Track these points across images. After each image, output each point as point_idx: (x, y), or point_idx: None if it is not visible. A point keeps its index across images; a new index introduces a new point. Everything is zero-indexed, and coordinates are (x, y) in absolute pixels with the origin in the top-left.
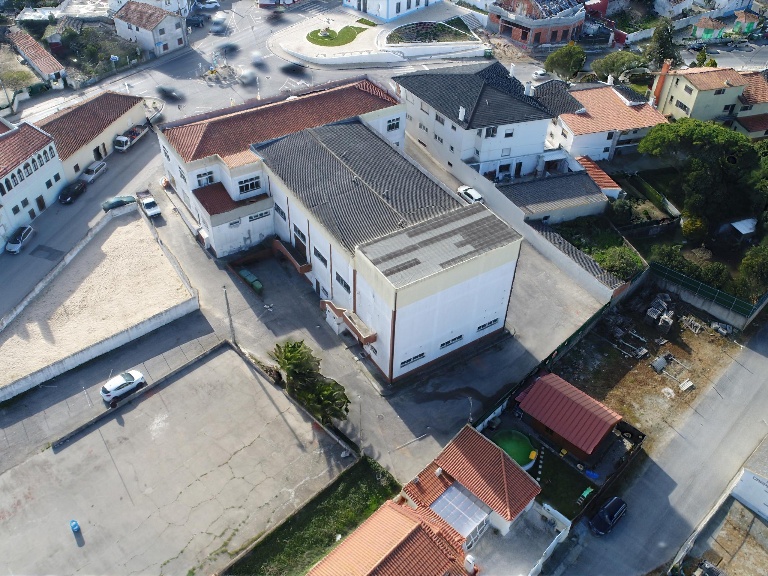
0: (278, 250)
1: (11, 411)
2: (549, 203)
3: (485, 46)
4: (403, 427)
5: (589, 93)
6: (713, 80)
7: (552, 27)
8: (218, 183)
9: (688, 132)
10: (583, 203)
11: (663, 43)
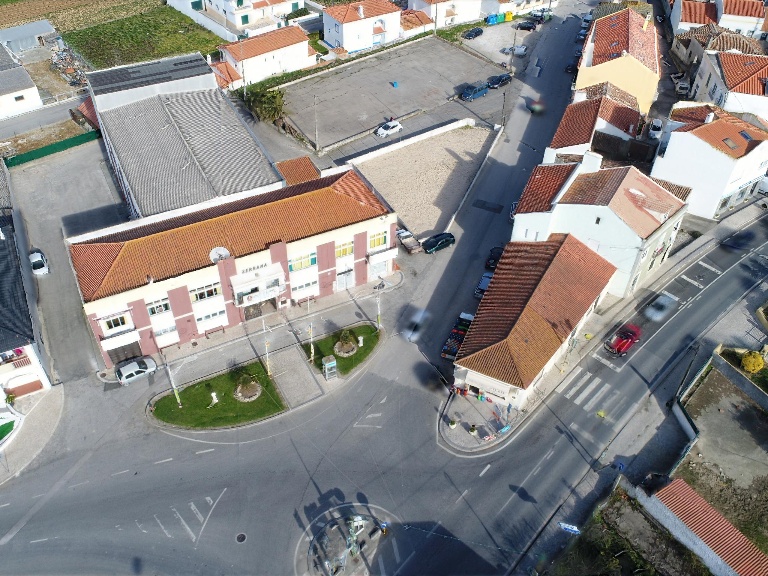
0: None
1: None
2: None
3: None
4: None
5: None
6: None
7: None
8: None
9: None
10: None
11: None
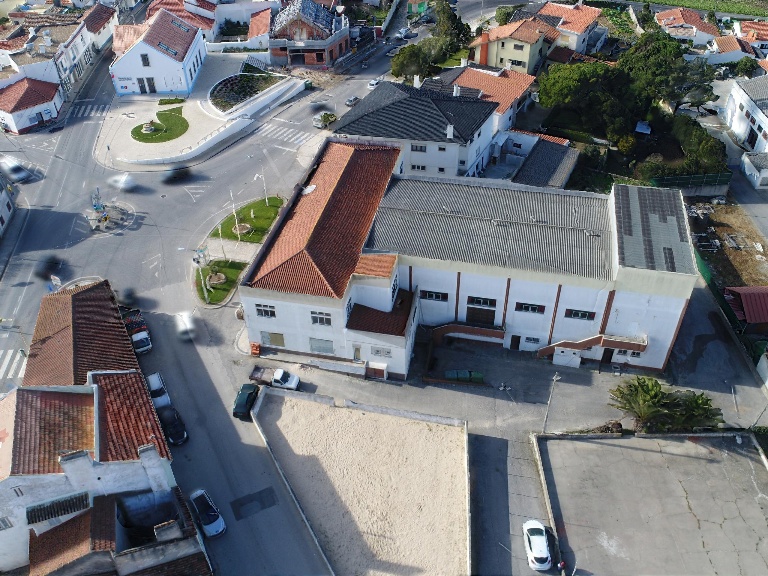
0: (442, 336)
1: None
2: (556, 174)
3: (299, 80)
4: (715, 394)
5: (463, 79)
6: (529, 33)
7: (338, 41)
8: (354, 306)
9: (581, 75)
10: (572, 162)
11: (453, 20)
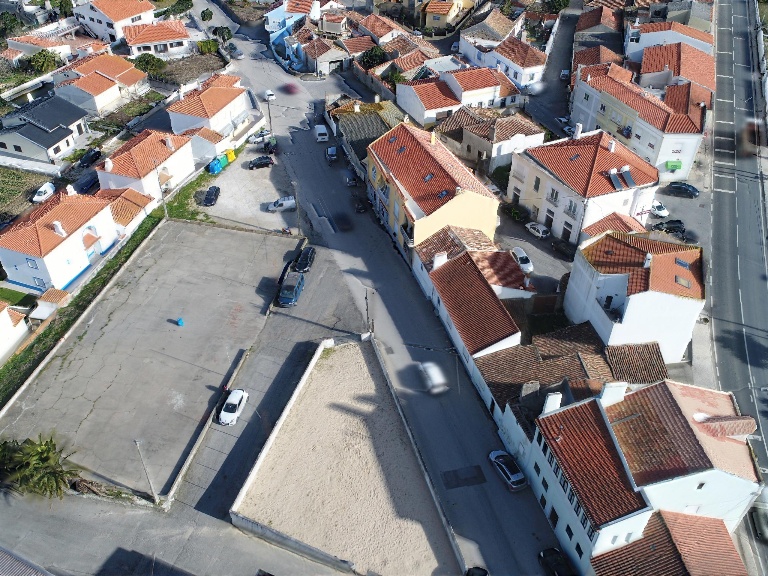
0: None
1: (307, 353)
2: None
3: None
4: None
5: None
6: None
7: None
8: None
9: None
10: None
11: None
